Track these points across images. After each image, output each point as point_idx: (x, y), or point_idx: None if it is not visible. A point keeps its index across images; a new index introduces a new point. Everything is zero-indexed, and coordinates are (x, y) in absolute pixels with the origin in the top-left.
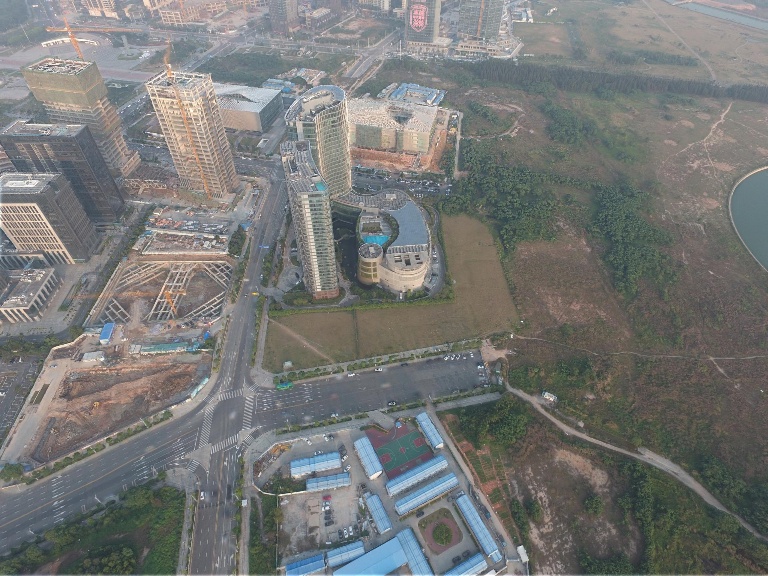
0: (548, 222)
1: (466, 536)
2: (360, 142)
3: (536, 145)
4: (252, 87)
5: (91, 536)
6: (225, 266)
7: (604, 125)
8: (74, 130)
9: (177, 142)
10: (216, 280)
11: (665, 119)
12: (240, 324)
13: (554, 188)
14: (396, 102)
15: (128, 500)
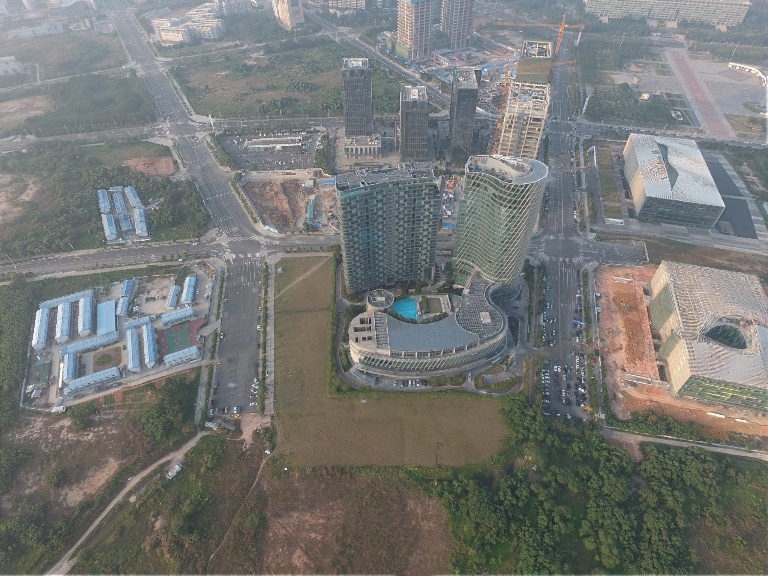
0: None
1: None
2: (653, 303)
3: None
4: (713, 183)
5: None
6: None
7: None
8: None
9: None
10: None
11: None
12: (328, 241)
13: None
14: None
15: (199, 213)
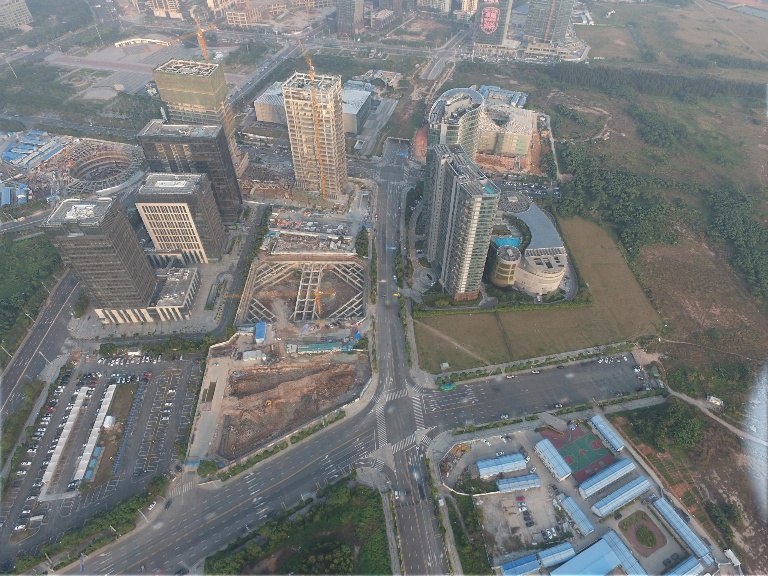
0: (665, 226)
1: (670, 539)
2: None
3: (631, 148)
4: None
5: (300, 533)
6: (355, 267)
7: (694, 129)
8: (211, 131)
9: (302, 143)
10: (347, 281)
11: (753, 123)
12: (386, 325)
13: (662, 192)
14: None
15: (332, 498)
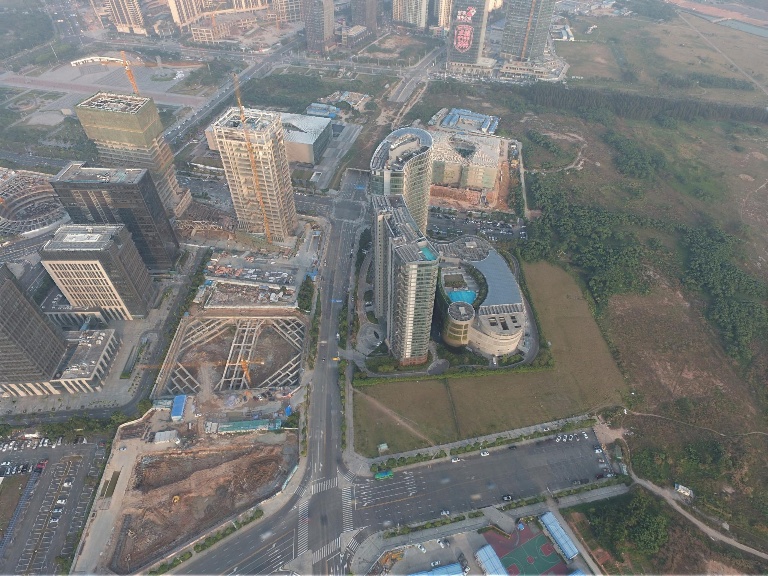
0: (637, 271)
1: None
2: None
3: (606, 180)
4: (301, 115)
5: None
6: (295, 323)
7: (673, 157)
8: (135, 175)
9: (240, 185)
10: (286, 338)
11: (735, 150)
12: (322, 395)
13: (636, 231)
14: (455, 133)
15: None
